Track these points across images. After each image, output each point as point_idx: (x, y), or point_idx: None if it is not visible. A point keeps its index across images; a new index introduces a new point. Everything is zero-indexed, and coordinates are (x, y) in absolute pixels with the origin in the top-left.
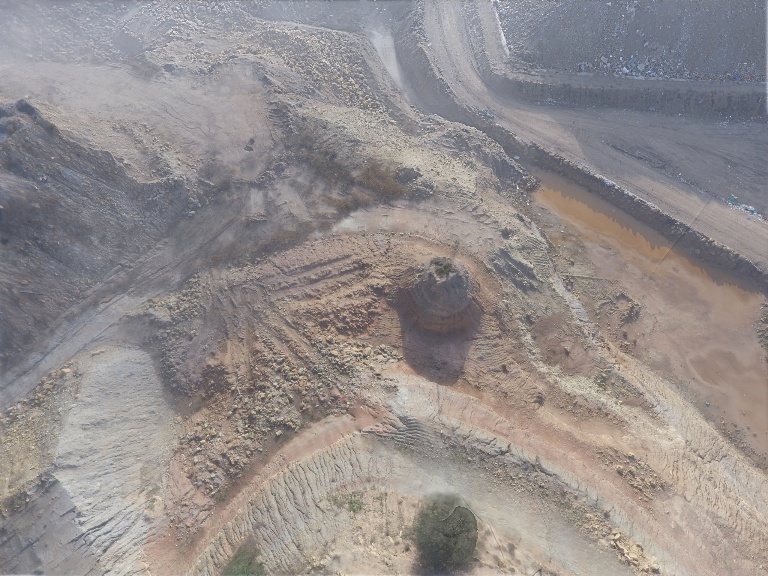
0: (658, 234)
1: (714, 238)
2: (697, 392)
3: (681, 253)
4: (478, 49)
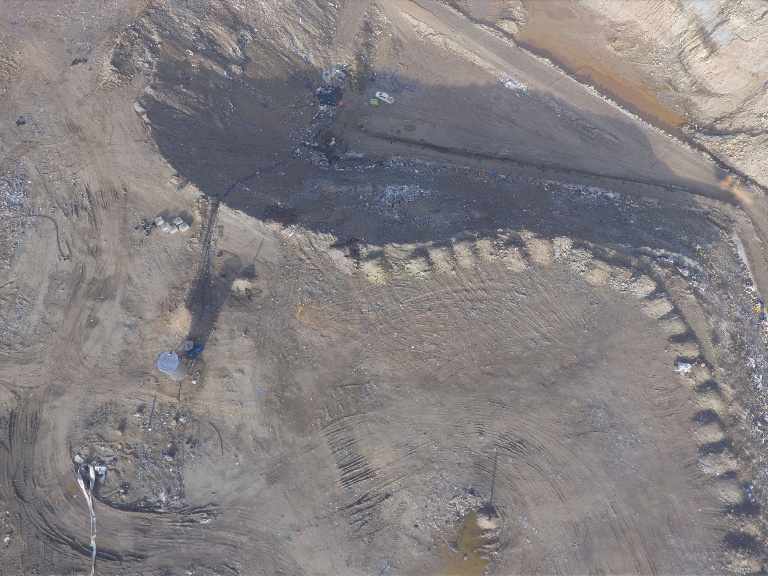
0: (584, 82)
1: (548, 67)
2: (577, 5)
3: (569, 69)
4: (765, 251)
